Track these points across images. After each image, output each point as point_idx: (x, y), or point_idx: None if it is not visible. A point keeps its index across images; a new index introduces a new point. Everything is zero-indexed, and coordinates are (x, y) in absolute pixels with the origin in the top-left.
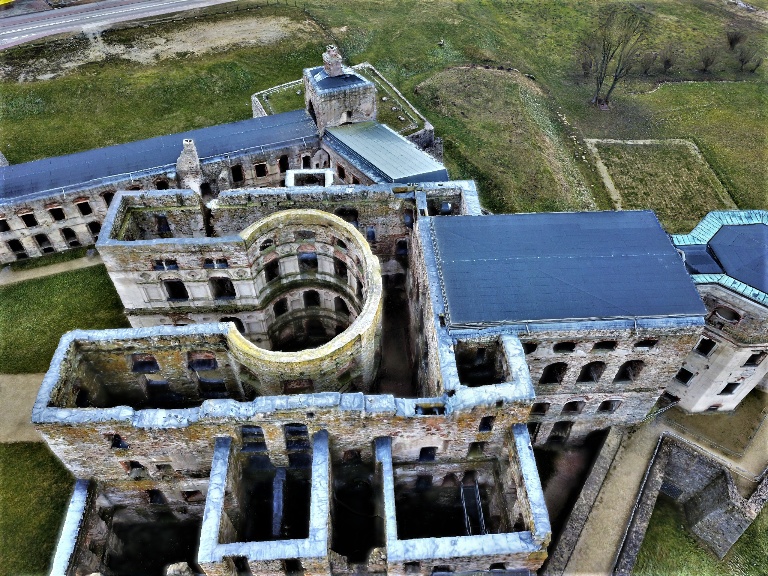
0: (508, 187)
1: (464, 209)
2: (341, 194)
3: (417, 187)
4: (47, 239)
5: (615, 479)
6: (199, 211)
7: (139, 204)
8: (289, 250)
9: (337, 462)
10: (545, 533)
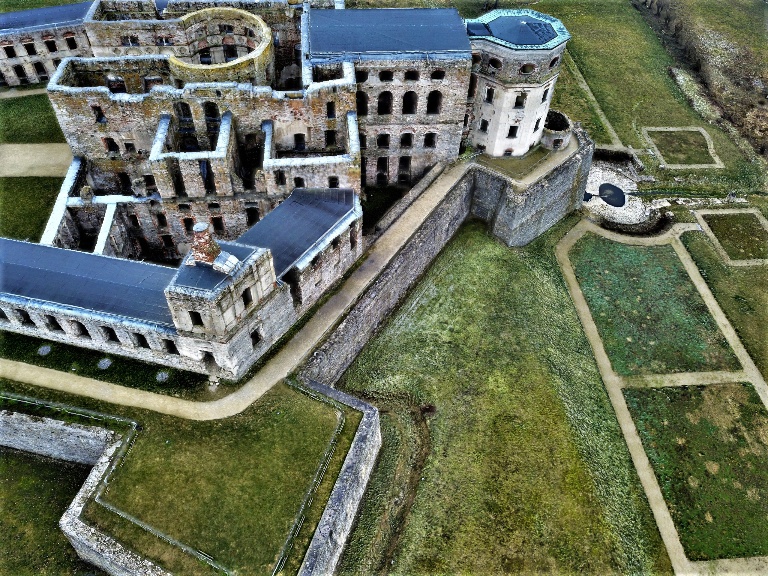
0: None
1: None
2: (252, 3)
3: (305, 0)
4: (43, 69)
5: (435, 188)
6: (154, 15)
7: (112, 9)
8: (217, 42)
9: (242, 148)
10: (356, 151)
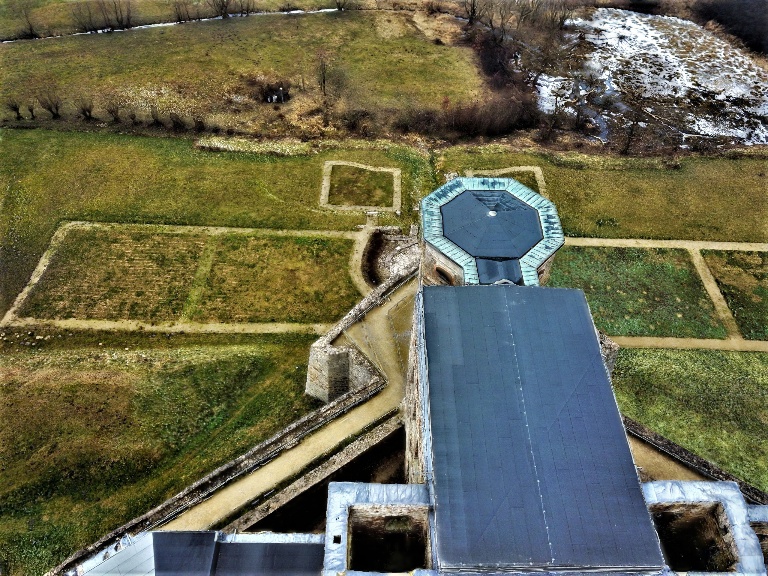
0: (93, 449)
1: (385, 510)
2: None
3: None
4: None
5: None
6: None
7: None
8: None
9: None
10: None
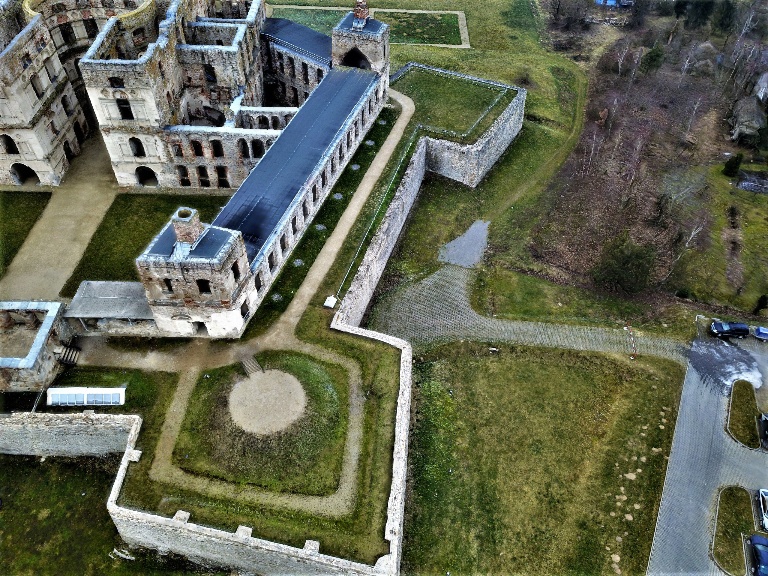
0: None
1: None
2: None
3: None
4: None
5: None
6: None
7: None
8: None
9: None
10: None
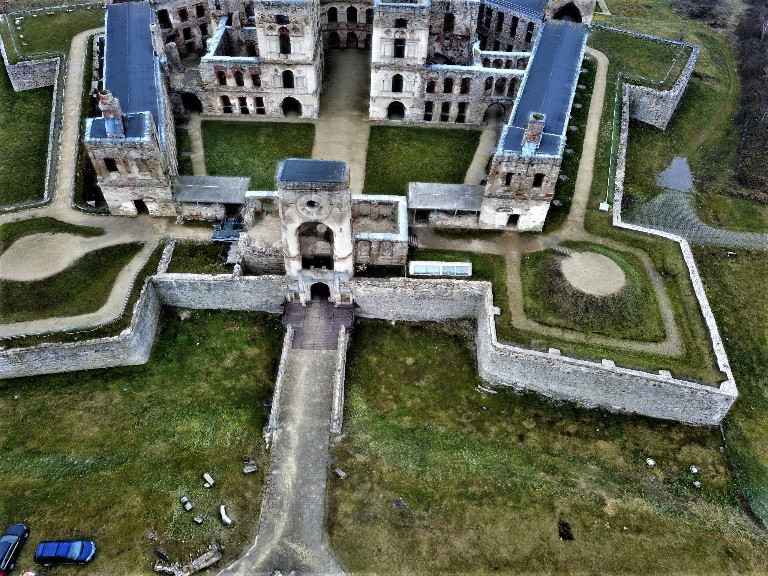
0: None
1: None
2: None
3: None
4: None
5: None
6: None
7: None
8: None
9: None
10: None
